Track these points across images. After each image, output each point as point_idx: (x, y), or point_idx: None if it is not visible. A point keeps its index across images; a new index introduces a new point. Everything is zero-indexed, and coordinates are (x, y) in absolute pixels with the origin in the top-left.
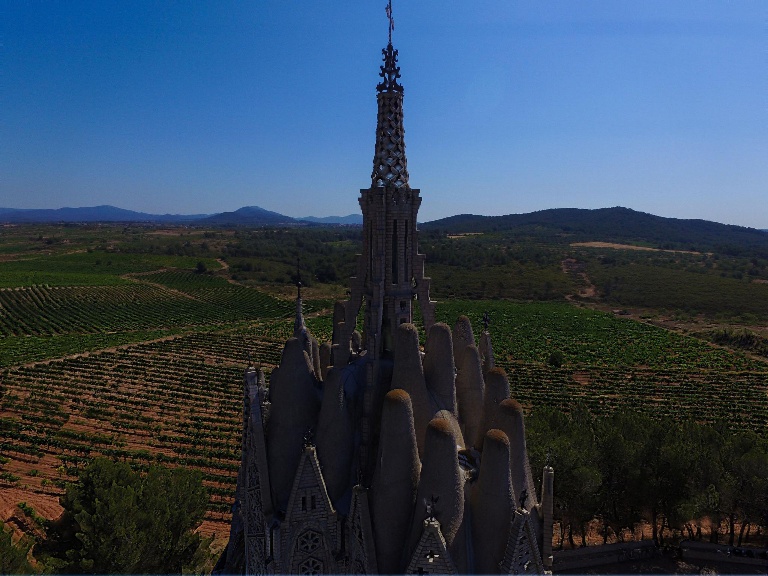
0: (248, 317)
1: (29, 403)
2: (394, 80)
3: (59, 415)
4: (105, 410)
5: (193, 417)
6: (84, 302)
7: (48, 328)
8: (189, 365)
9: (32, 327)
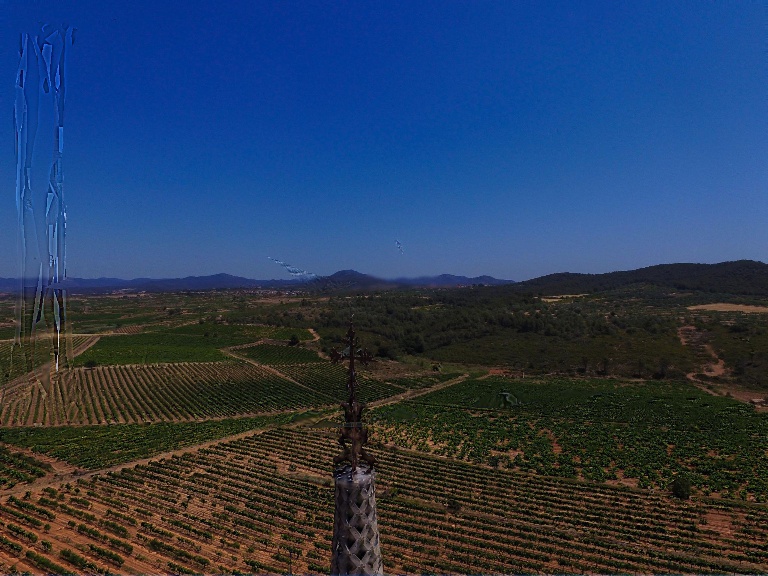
0: (331, 401)
1: (103, 525)
2: (360, 447)
3: (124, 546)
4: (169, 539)
5: (249, 561)
6: (186, 381)
7: (150, 412)
8: (260, 476)
9: (137, 411)
